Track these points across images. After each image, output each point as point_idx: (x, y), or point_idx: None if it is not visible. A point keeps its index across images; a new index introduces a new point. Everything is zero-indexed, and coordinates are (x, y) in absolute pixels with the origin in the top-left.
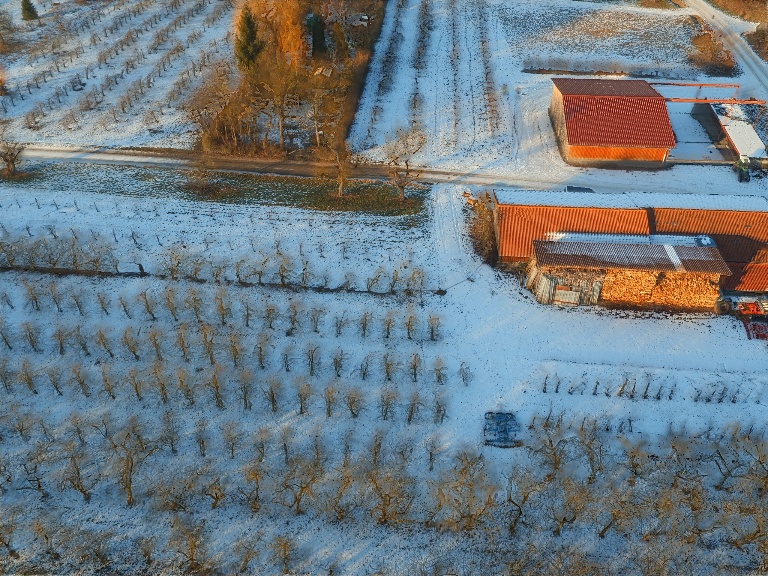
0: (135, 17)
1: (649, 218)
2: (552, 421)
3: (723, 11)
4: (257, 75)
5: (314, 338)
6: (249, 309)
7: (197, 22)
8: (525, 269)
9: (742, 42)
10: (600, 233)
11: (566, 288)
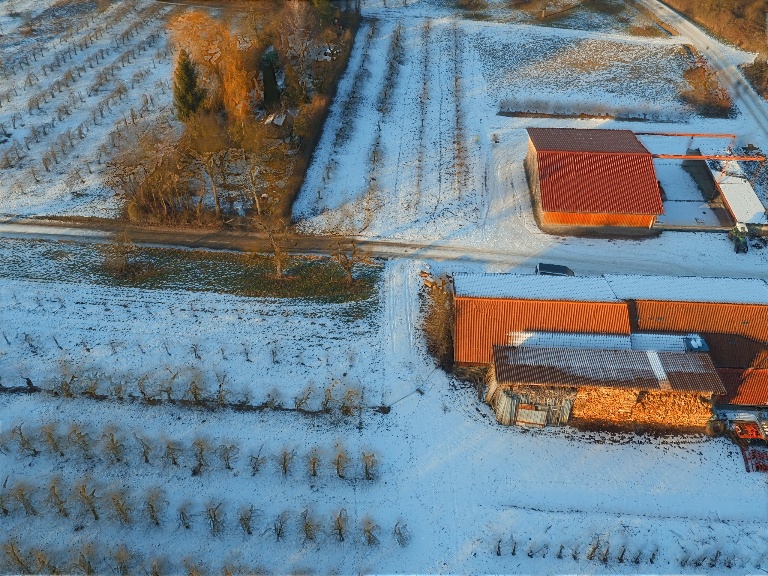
0: (82, 51)
1: (630, 313)
2: None
3: (718, 39)
4: (199, 126)
5: (226, 478)
6: (145, 447)
7: (148, 56)
8: (485, 376)
9: (739, 76)
10: (573, 333)
11: (530, 407)
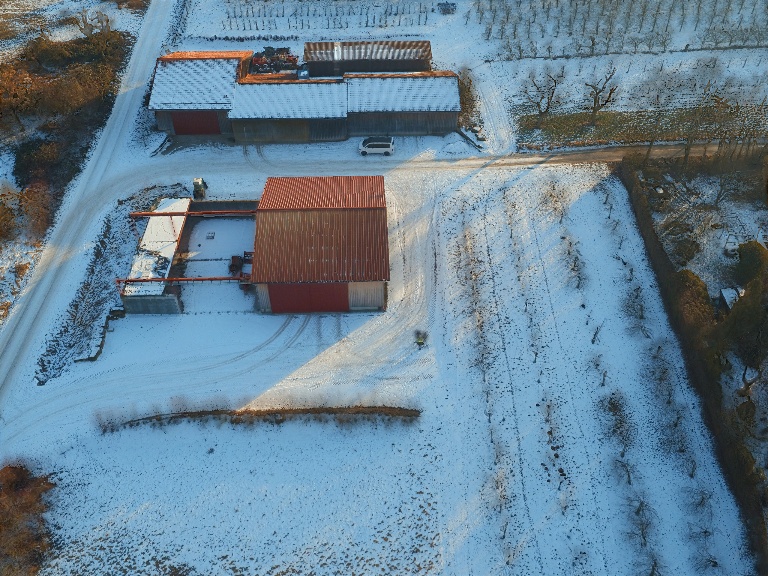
0: None
1: None
2: None
3: None
4: None
5: None
6: None
7: None
8: None
9: None
10: None
11: None
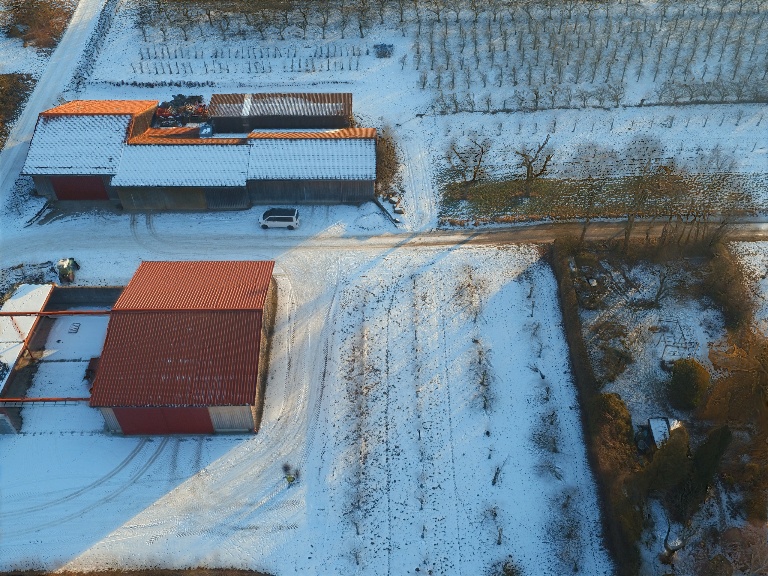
0: None
1: None
2: None
3: None
4: None
5: None
6: None
7: None
8: None
9: None
10: None
11: None
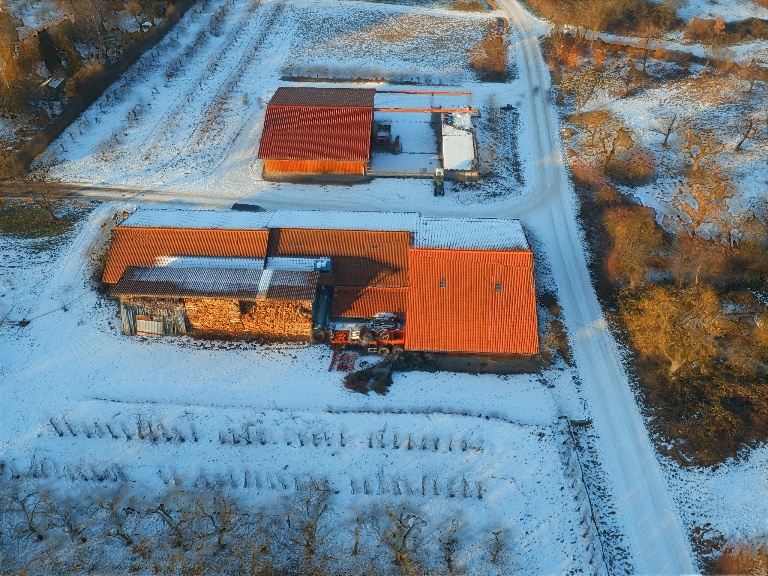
0: None
1: (273, 239)
2: (30, 471)
3: (533, 13)
4: None
5: None
6: None
7: None
8: None
9: (535, 45)
10: (214, 256)
11: (146, 318)
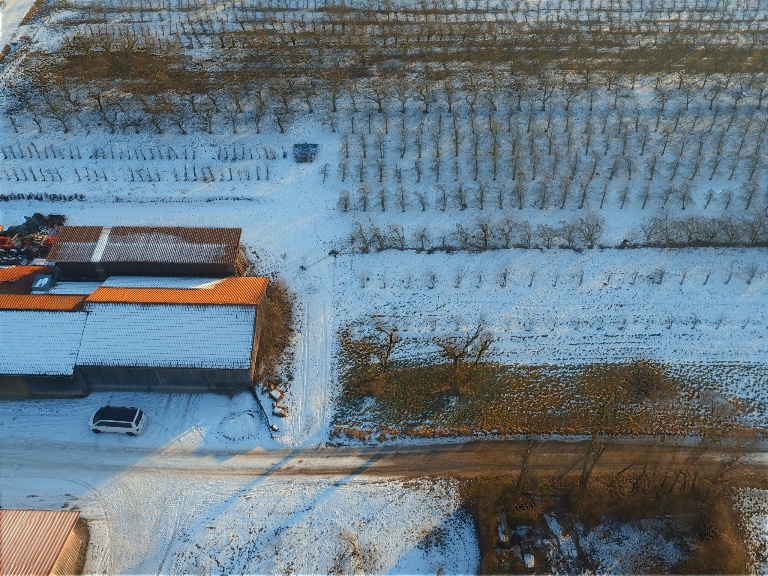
0: None
1: None
2: None
3: None
4: None
5: None
6: None
7: None
8: None
9: None
10: (152, 288)
11: None
